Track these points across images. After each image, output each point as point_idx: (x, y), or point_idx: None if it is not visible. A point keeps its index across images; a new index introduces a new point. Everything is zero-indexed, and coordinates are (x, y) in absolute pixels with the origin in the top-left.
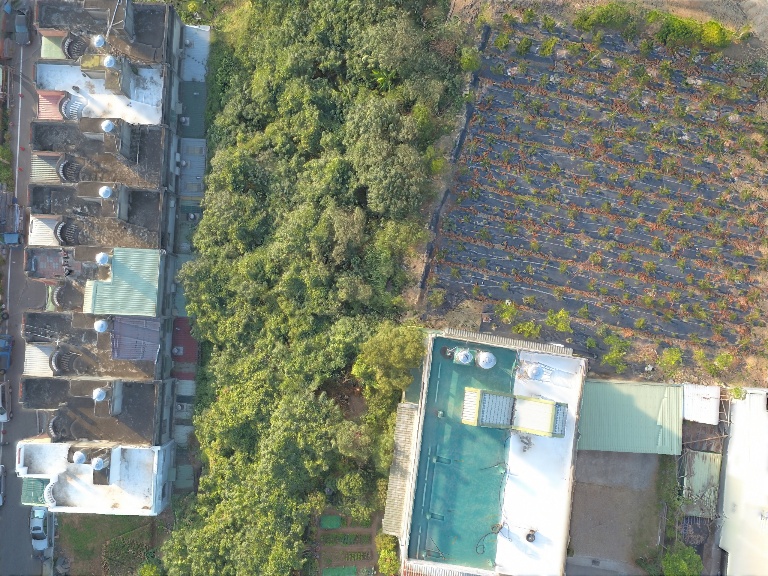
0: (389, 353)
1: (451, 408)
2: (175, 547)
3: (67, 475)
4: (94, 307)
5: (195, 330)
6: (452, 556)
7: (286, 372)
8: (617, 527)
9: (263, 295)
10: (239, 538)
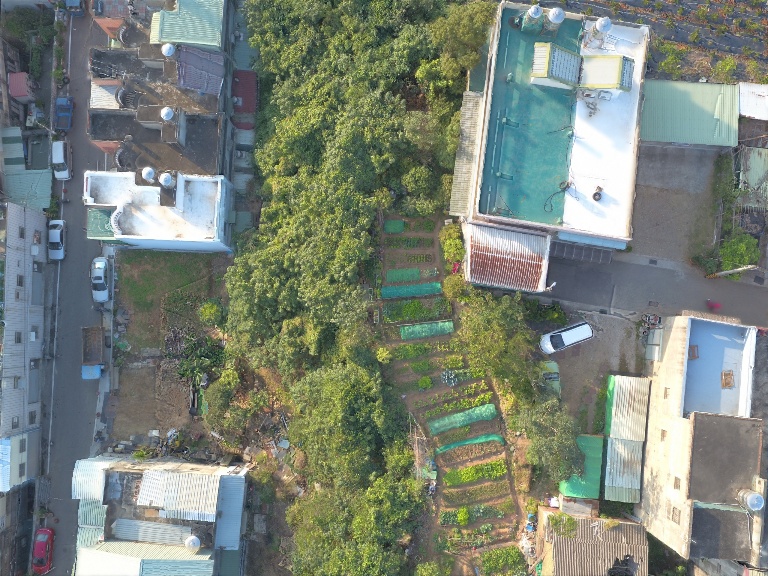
0: (458, 26)
1: (519, 74)
2: (238, 270)
3: (132, 207)
4: (161, 34)
5: (257, 64)
6: (521, 214)
7: (351, 81)
8: (674, 228)
9: (328, 11)
10: (303, 249)
